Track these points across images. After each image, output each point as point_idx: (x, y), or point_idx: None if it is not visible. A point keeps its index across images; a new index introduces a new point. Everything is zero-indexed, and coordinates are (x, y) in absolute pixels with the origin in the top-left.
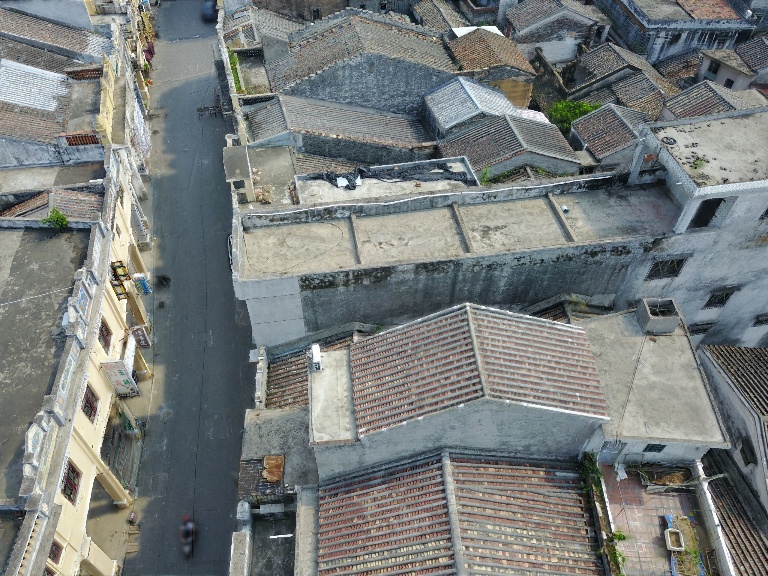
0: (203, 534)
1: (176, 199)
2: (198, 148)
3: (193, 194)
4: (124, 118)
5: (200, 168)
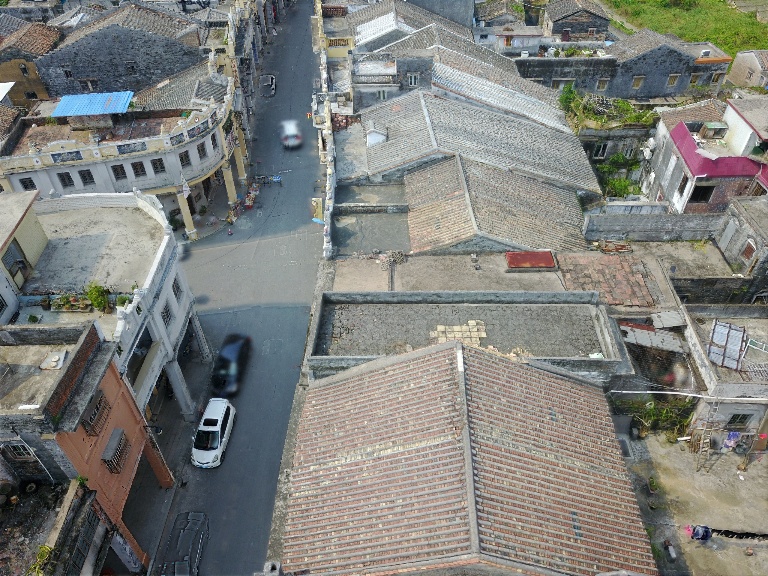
0: (303, 31)
1: (308, 124)
2: (287, 157)
3: (295, 126)
4: (312, 28)
5: (287, 142)
